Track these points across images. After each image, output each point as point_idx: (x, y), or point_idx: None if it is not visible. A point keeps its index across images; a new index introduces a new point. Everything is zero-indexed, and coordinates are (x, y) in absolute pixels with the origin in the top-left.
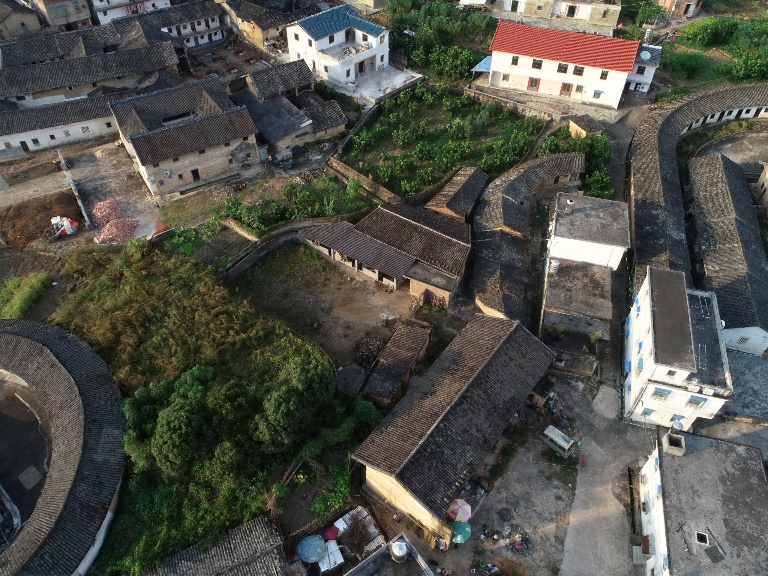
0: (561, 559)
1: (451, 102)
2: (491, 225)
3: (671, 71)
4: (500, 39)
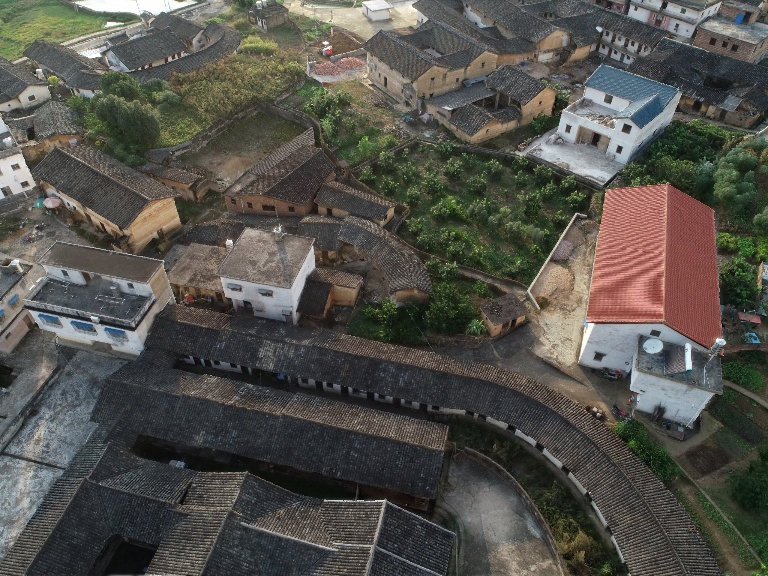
0: (10, 255)
1: (530, 198)
2: (304, 219)
3: (760, 475)
4: (629, 192)
